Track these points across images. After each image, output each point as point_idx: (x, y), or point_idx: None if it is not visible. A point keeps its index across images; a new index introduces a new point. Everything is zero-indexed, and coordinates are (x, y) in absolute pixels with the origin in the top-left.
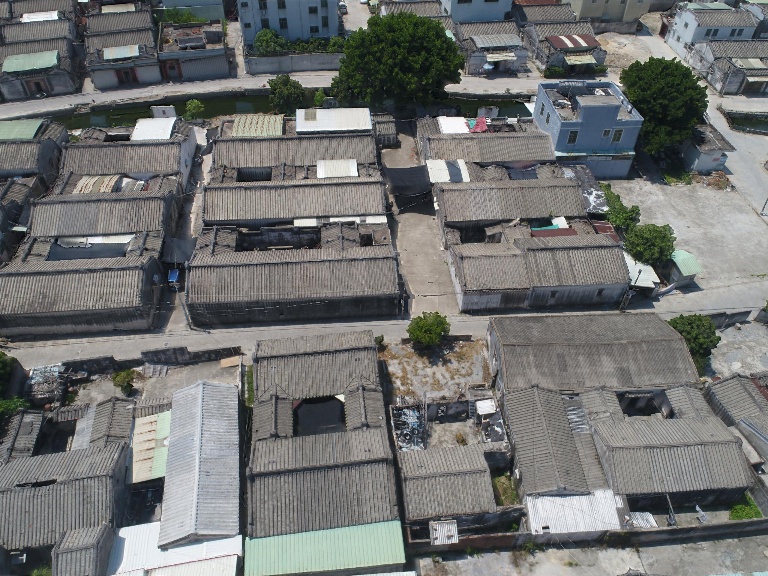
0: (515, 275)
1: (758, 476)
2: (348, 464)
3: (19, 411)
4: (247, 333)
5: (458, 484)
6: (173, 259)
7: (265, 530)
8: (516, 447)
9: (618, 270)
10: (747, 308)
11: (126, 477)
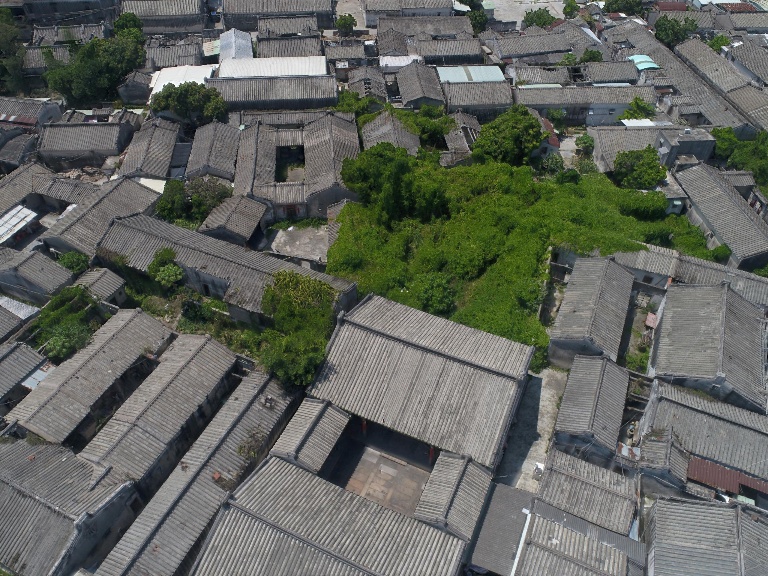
0: (393, 5)
1: (488, 55)
2: (300, 38)
3: (149, 37)
4: (254, 33)
5: (349, 49)
6: (213, 6)
7: (265, 57)
8: (379, 46)
9: (447, 2)
10: (519, 26)
11: (202, 55)
